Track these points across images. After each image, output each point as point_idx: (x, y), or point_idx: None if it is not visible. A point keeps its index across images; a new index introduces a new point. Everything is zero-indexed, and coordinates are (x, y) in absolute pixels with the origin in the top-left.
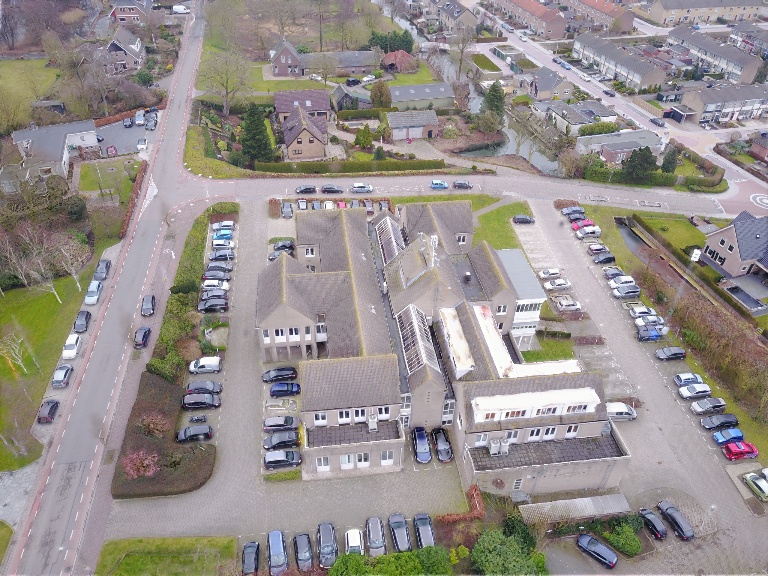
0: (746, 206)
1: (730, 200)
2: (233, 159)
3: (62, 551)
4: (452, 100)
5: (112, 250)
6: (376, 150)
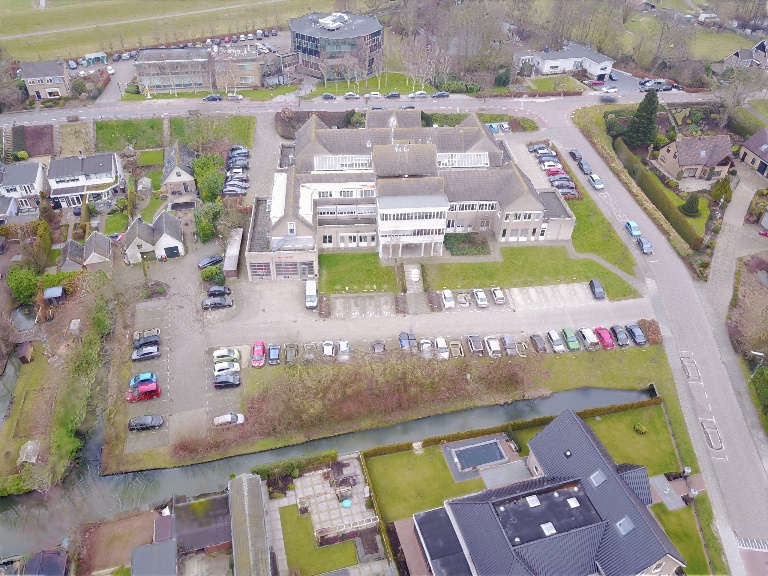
0: None
1: None
2: (610, 123)
3: None
4: None
5: (464, 97)
6: (691, 195)
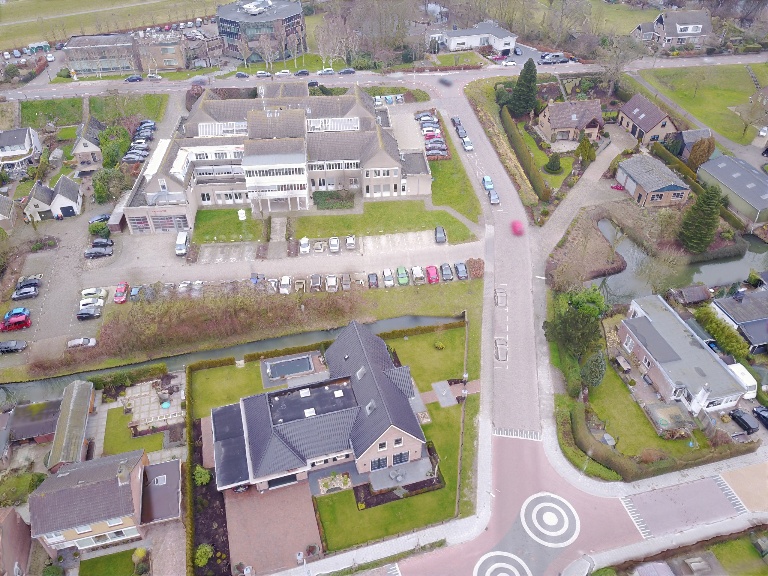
0: (524, 475)
1: (541, 459)
2: (498, 93)
3: (171, 88)
4: (756, 213)
5: (369, 72)
6: None
